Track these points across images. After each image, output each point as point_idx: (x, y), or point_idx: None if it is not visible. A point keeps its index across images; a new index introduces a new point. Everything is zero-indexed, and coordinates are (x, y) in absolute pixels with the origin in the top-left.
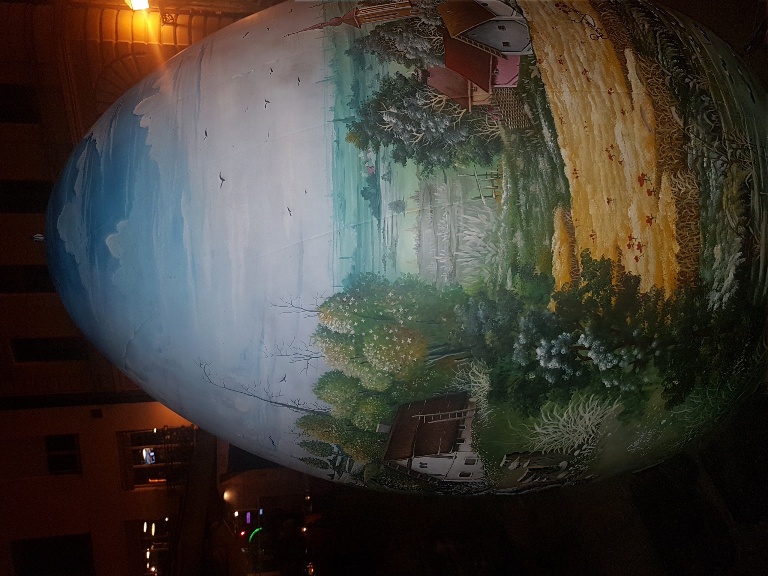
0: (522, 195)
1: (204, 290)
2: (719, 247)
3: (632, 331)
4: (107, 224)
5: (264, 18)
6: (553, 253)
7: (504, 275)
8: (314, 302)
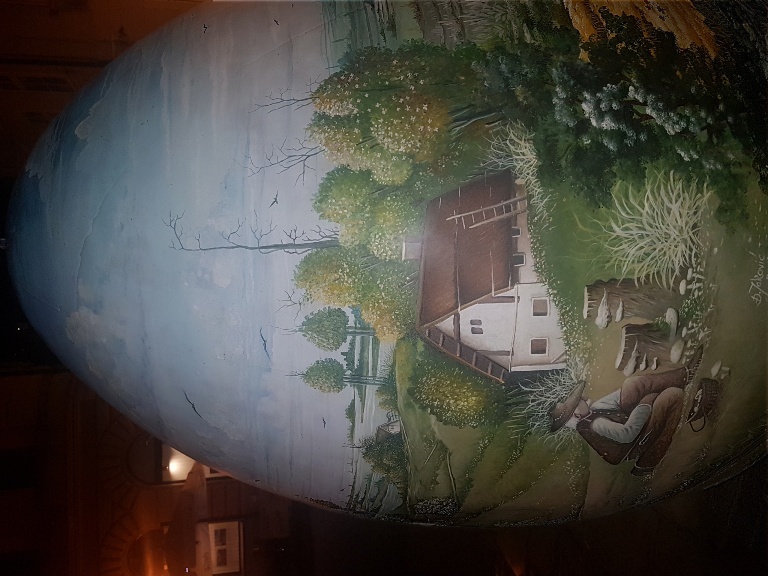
0: None
1: (180, 122)
2: (747, 25)
3: (688, 88)
4: (79, 118)
5: None
6: (568, 10)
7: (520, 30)
8: (307, 89)
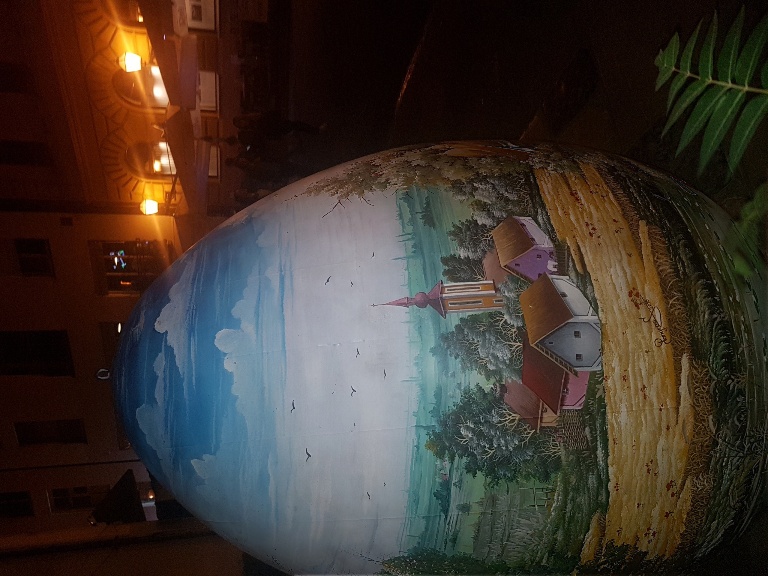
0: (569, 505)
1: (284, 526)
2: (716, 521)
3: None
4: (192, 448)
5: (344, 250)
6: (584, 544)
7: (541, 557)
8: (381, 557)
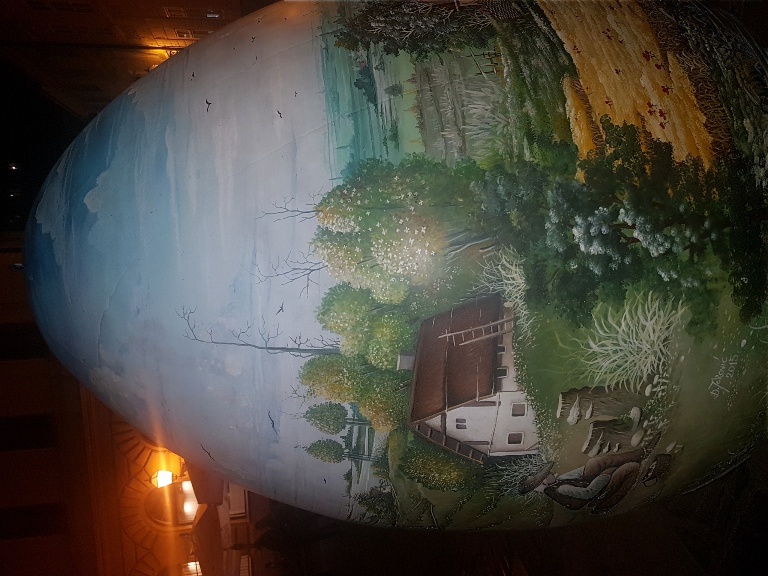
0: (524, 68)
1: (188, 217)
2: (748, 121)
3: (678, 206)
4: (87, 183)
5: None
6: (569, 120)
7: (520, 145)
8: (311, 201)
